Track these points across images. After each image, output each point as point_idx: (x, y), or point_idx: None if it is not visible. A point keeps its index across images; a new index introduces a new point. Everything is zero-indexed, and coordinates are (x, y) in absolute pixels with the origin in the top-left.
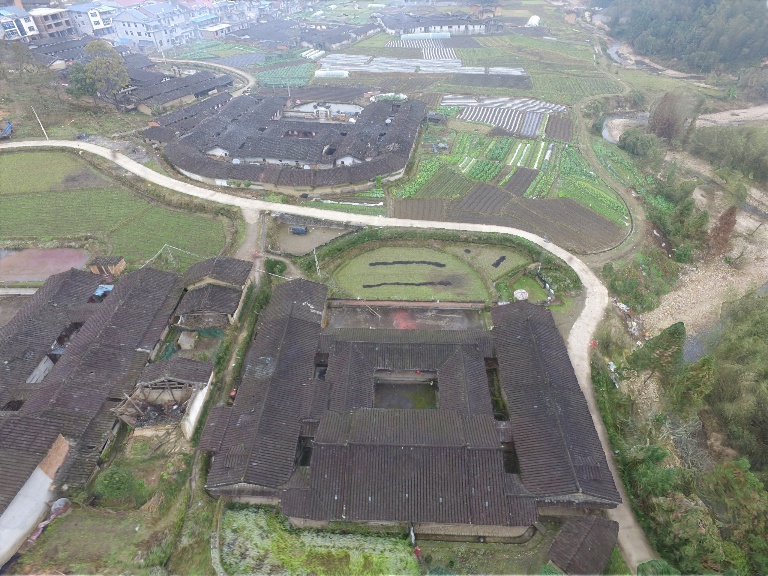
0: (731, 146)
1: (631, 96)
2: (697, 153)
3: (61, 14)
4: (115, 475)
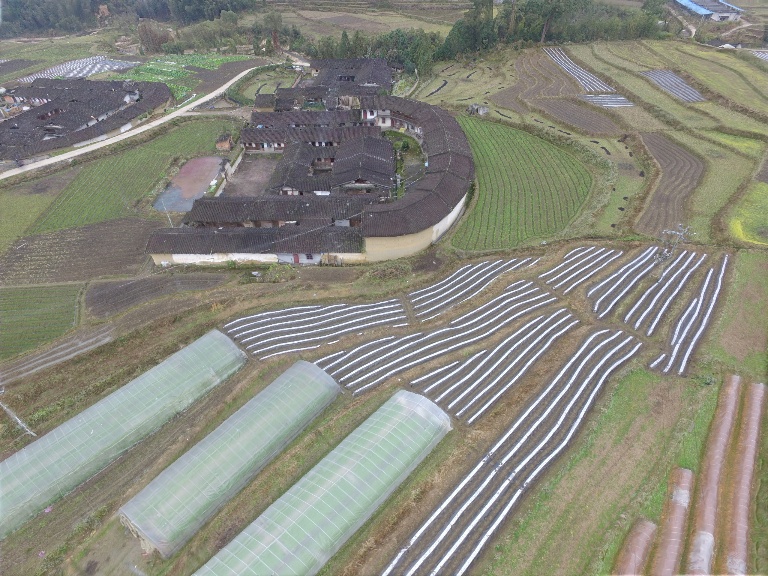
0: (207, 32)
1: (105, 43)
2: (190, 47)
3: None
4: None
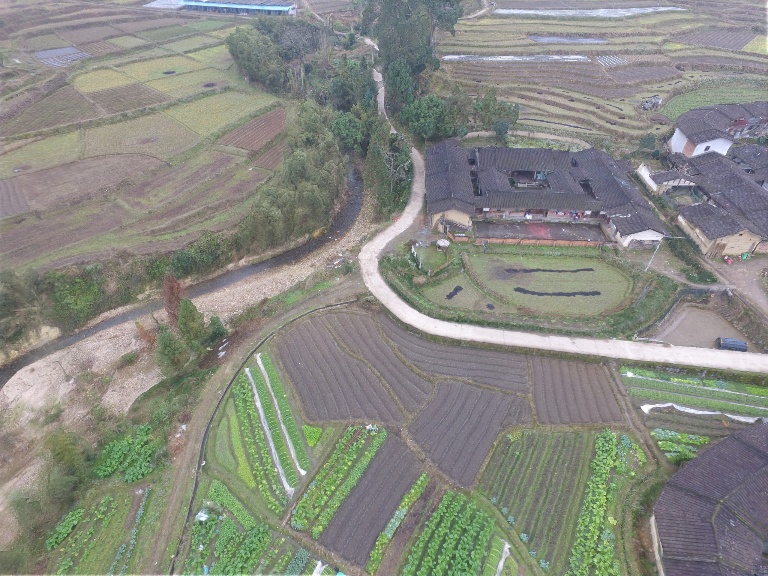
0: None
1: None
2: None
3: None
4: (647, 135)
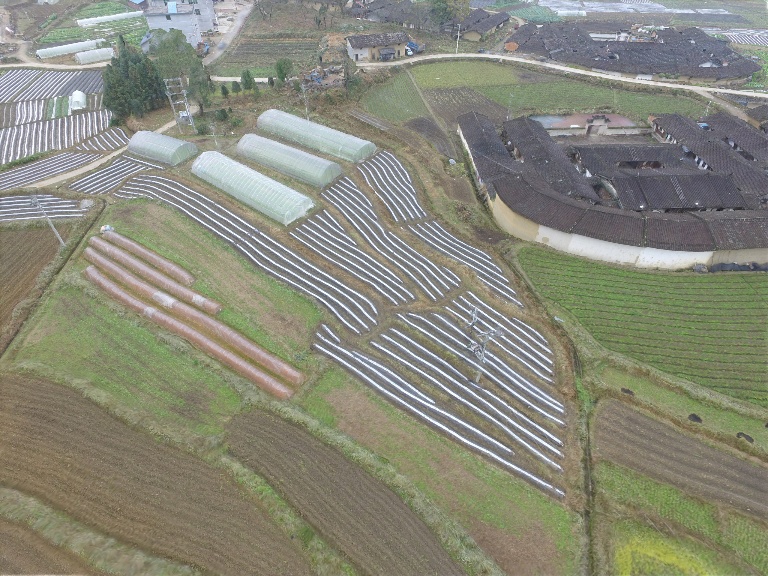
0: None
1: None
2: None
3: None
4: None
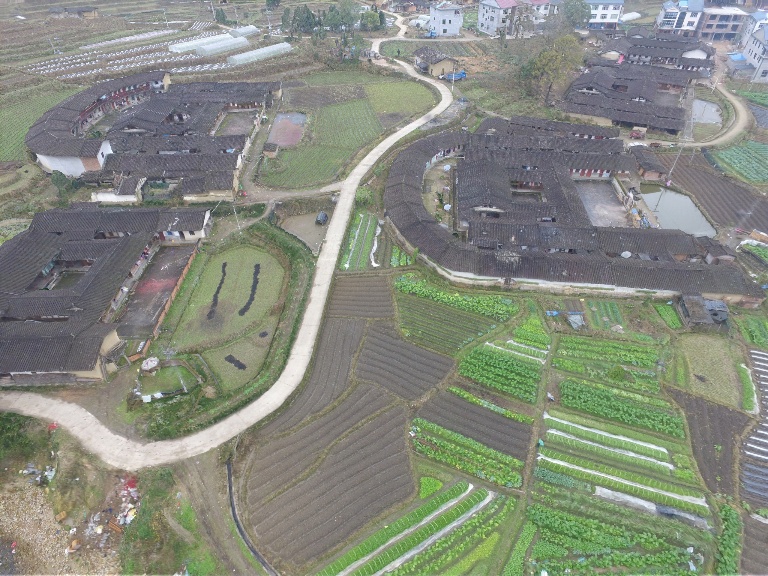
0: None
1: None
2: None
3: (736, 17)
4: (54, 174)
